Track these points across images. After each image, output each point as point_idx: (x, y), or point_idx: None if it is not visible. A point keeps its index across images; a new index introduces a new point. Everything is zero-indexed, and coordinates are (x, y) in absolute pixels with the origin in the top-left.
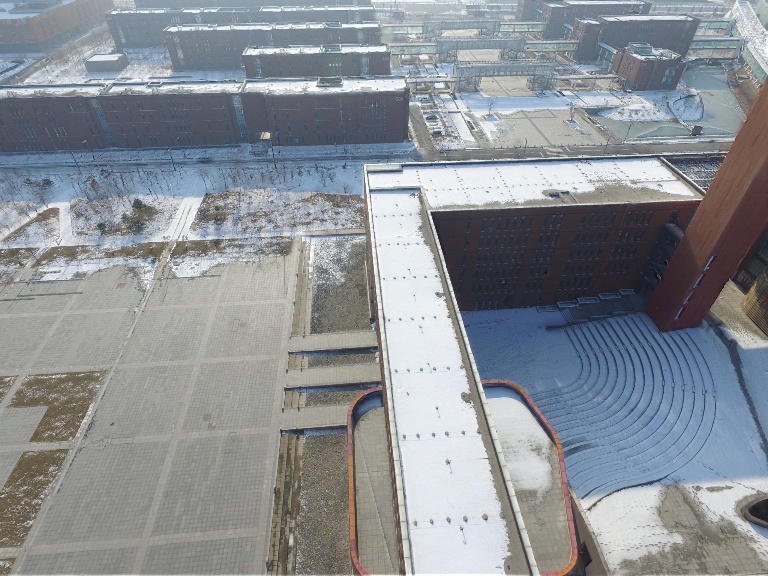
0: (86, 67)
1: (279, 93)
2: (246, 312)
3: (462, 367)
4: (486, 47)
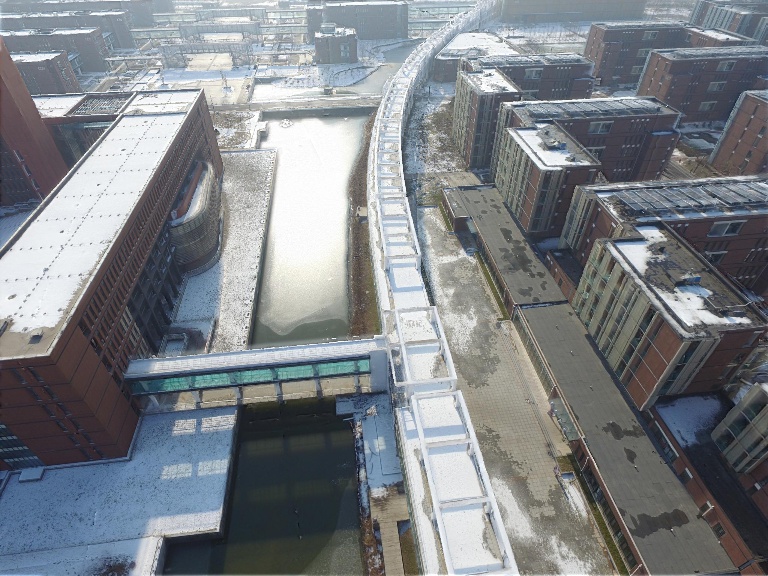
0: None
1: None
2: None
3: None
4: (225, 31)
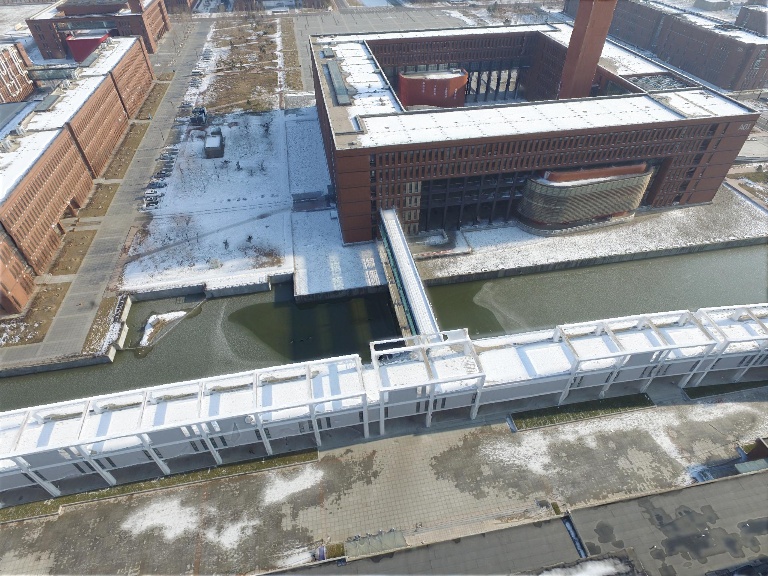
0: (695, 3)
1: (684, 21)
2: None
3: None
4: None
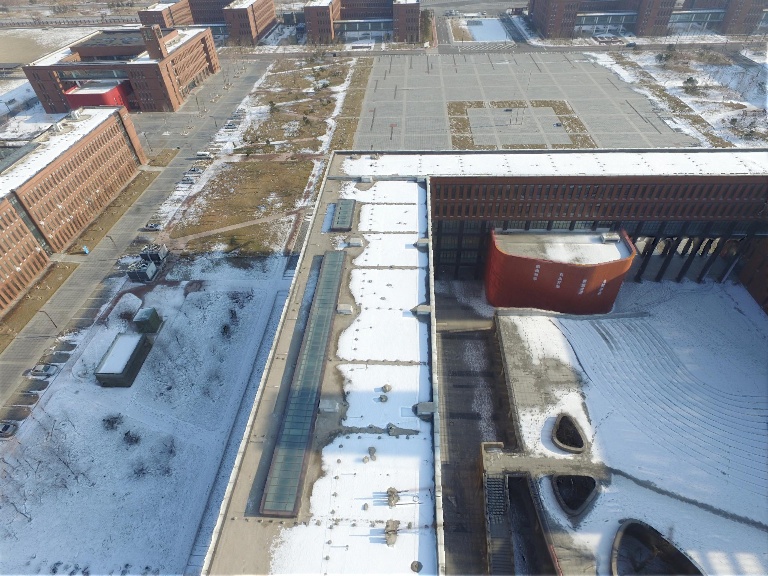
0: None
1: None
2: None
3: None
4: None
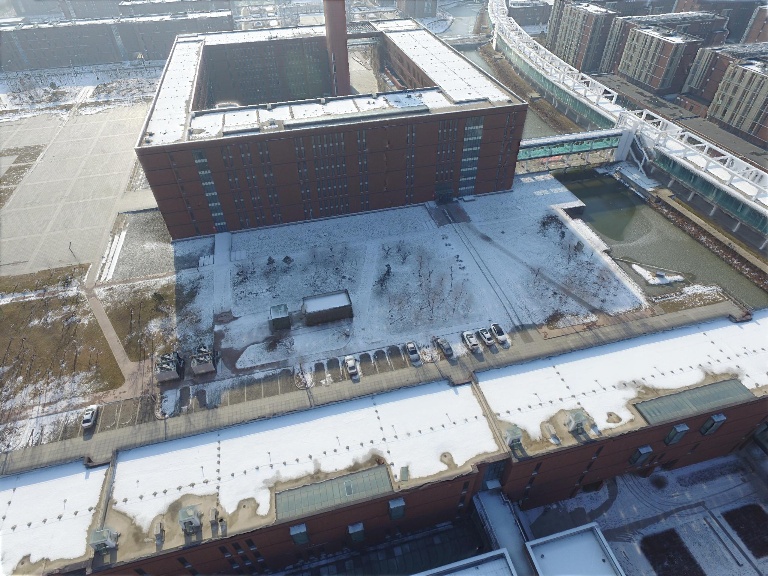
0: None
1: (143, 22)
2: (124, 122)
3: (193, 76)
4: None
